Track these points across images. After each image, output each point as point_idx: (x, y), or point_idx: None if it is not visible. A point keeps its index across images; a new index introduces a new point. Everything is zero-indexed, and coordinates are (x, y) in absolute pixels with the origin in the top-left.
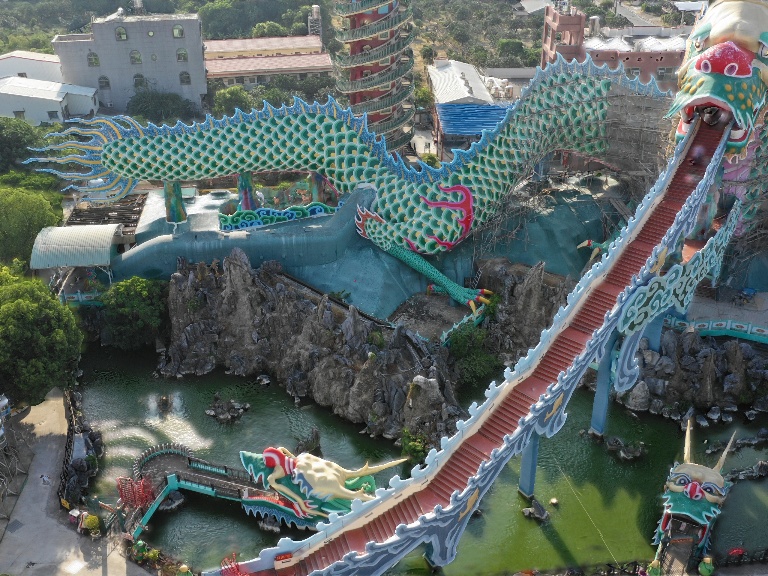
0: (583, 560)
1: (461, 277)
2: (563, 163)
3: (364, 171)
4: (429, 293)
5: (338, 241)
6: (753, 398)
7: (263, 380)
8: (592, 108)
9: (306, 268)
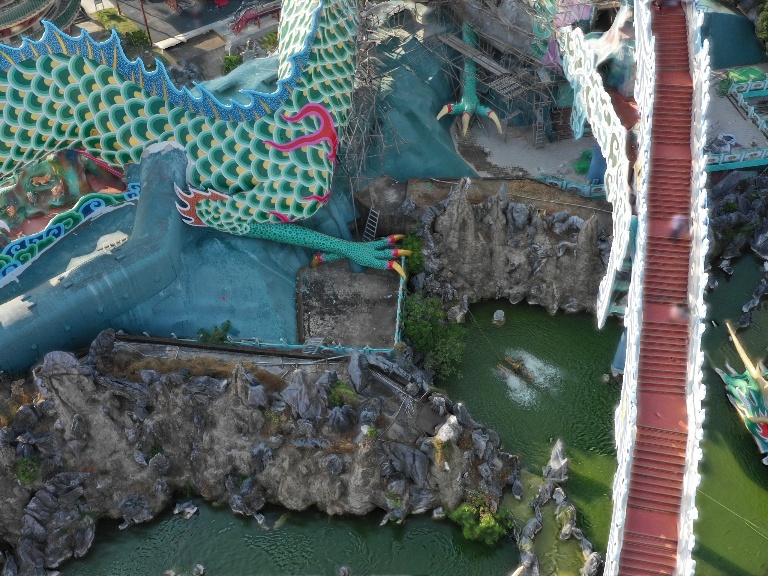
0: (744, 561)
1: (343, 224)
2: None
3: (147, 124)
4: (315, 264)
5: (171, 252)
6: (722, 248)
7: (186, 511)
8: None
9: (137, 309)
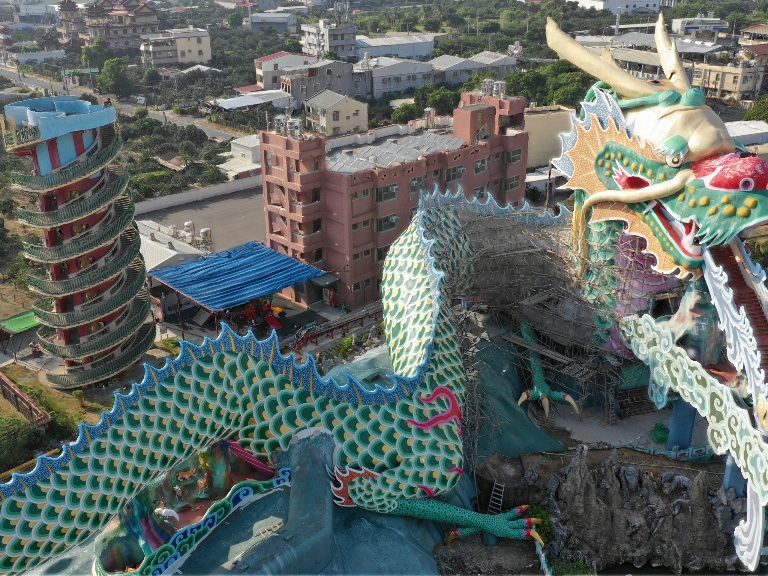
0: None
1: (467, 501)
2: (330, 303)
3: (297, 412)
4: (449, 541)
5: (330, 531)
6: None
7: None
8: (461, 243)
9: None
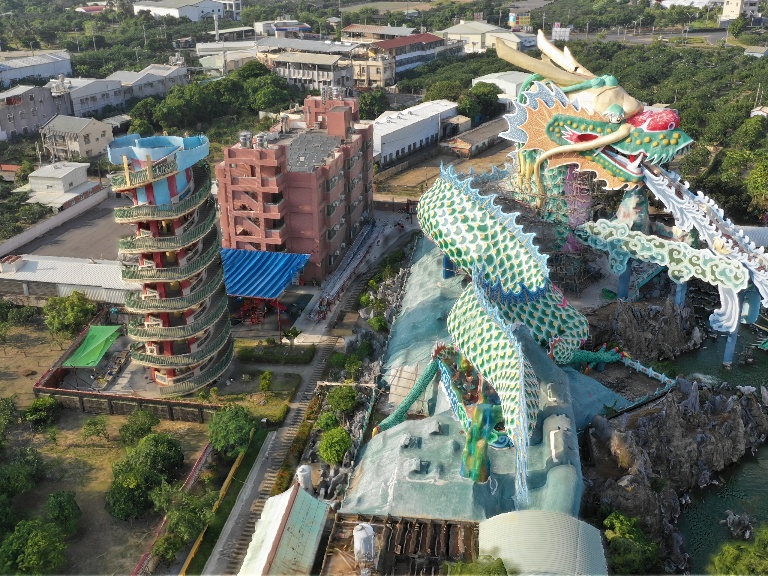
0: None
1: None
2: (300, 283)
3: (503, 316)
4: None
5: None
6: None
7: (687, 500)
8: None
9: None
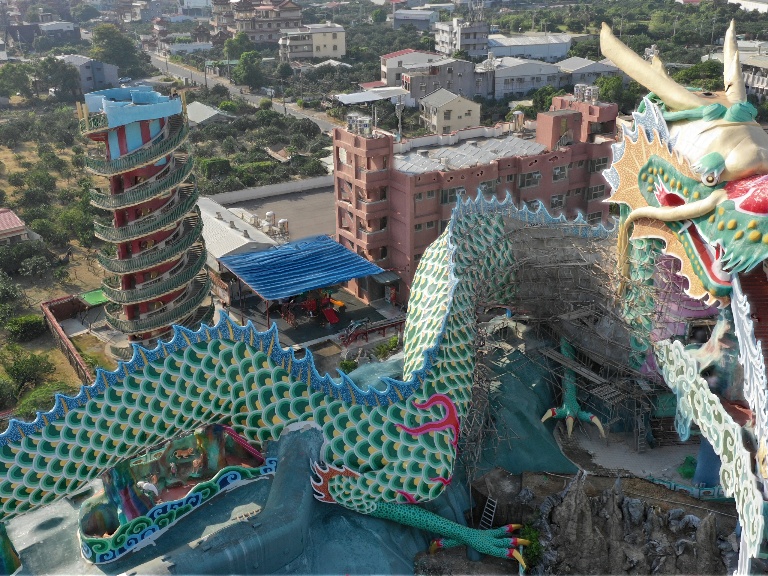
0: None
1: (460, 513)
2: (391, 301)
3: (290, 405)
4: (433, 551)
5: (302, 524)
6: None
7: None
8: (500, 251)
9: None
